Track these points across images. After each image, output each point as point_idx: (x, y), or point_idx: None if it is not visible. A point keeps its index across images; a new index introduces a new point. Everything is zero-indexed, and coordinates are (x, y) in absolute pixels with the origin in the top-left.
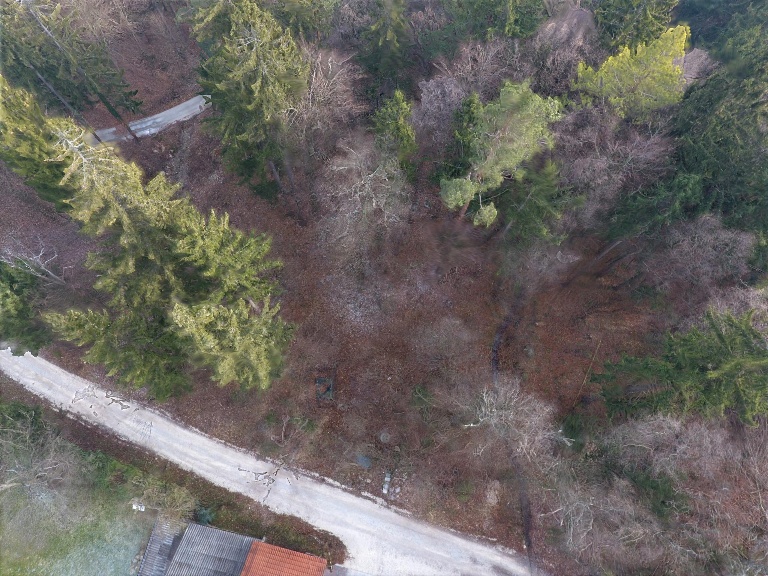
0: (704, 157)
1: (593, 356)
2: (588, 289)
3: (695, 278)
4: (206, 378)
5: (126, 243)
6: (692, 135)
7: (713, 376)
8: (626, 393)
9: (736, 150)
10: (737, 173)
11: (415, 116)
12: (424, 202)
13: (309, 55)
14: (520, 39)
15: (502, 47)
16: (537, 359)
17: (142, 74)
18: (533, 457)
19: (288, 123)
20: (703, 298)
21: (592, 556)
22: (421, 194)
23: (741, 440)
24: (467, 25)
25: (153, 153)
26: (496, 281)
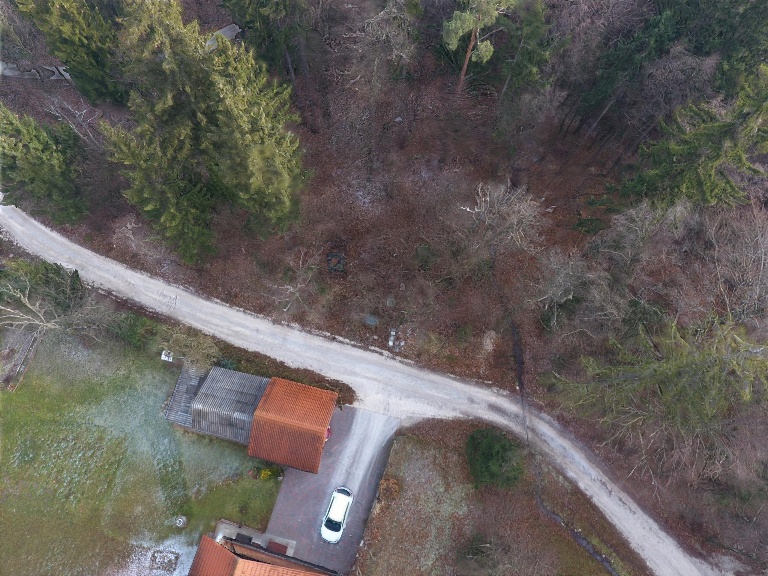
0: (677, 4)
1: (582, 228)
2: (579, 176)
3: (668, 108)
4: (226, 257)
5: (167, 69)
6: None
7: (678, 168)
8: None
9: None
10: (705, 14)
11: None
12: (428, 104)
13: None
14: None
15: None
16: None
17: None
18: (522, 244)
19: None
20: None
21: (573, 339)
22: (425, 98)
23: None
24: None
25: None
26: (494, 168)
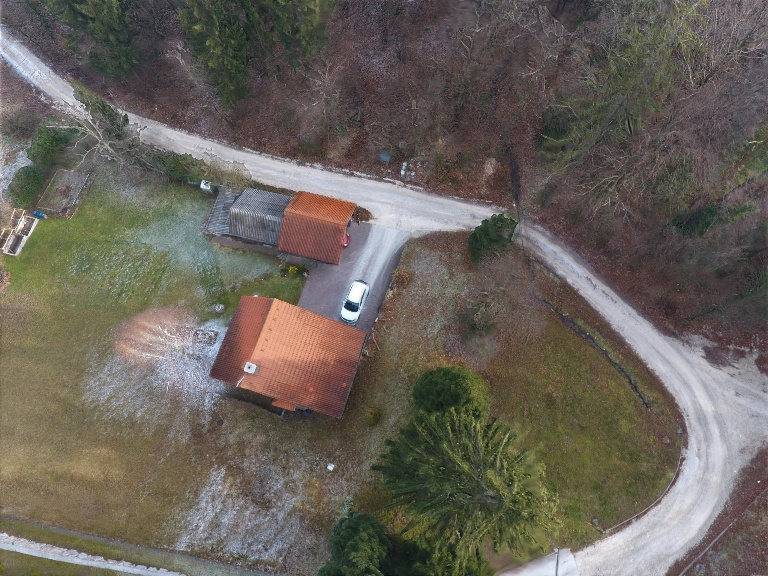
0: None
1: None
2: None
3: None
4: (256, 114)
5: None
6: None
7: None
8: None
9: None
10: None
11: None
12: None
13: None
14: None
15: None
16: None
17: None
18: None
19: None
20: None
21: (559, 108)
22: None
23: (669, 5)
24: None
25: None
26: None
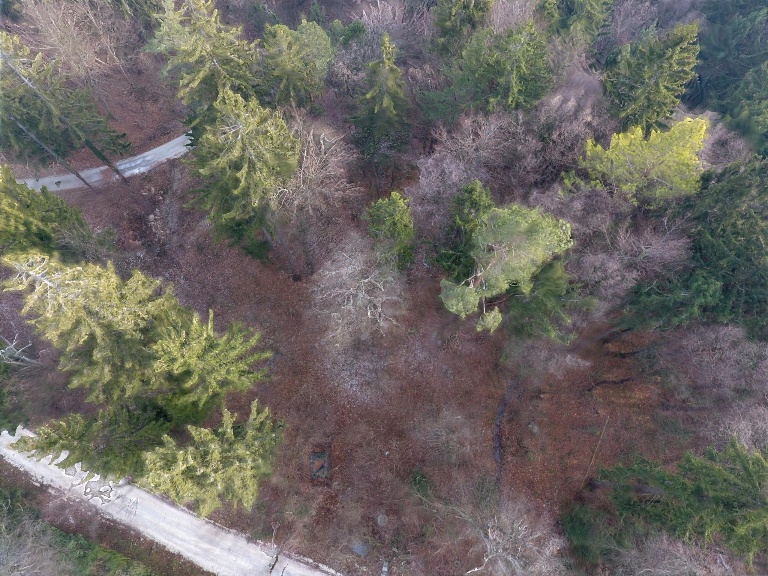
0: (724, 255)
1: (601, 433)
2: (595, 356)
3: (715, 387)
4: None
5: (100, 357)
6: (709, 224)
7: (739, 514)
8: (639, 495)
9: (760, 252)
10: (760, 274)
11: (413, 200)
12: (423, 260)
13: (300, 124)
14: (524, 109)
15: (505, 122)
16: (542, 436)
17: (132, 107)
18: None
19: (277, 206)
20: (724, 408)
21: None
22: (419, 251)
23: None
24: (468, 91)
25: (142, 196)
26: (498, 349)
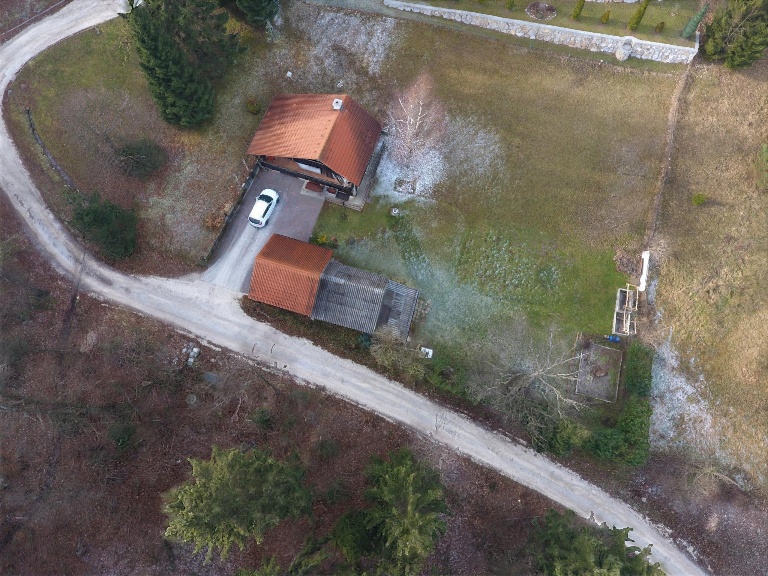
0: None
1: None
2: None
3: None
4: None
5: None
6: None
7: None
8: None
9: None
10: None
11: None
12: None
13: None
14: None
15: None
16: None
17: None
18: None
19: None
20: None
21: None
22: None
23: None
24: None
25: None
26: None
